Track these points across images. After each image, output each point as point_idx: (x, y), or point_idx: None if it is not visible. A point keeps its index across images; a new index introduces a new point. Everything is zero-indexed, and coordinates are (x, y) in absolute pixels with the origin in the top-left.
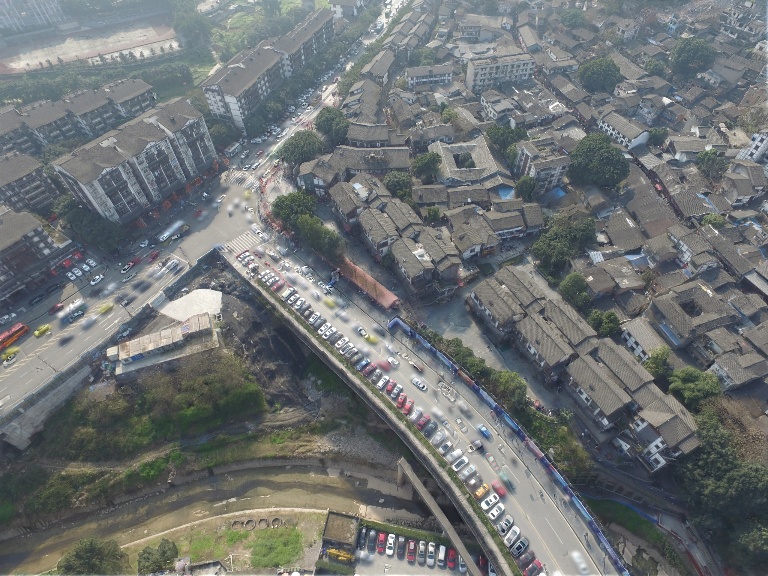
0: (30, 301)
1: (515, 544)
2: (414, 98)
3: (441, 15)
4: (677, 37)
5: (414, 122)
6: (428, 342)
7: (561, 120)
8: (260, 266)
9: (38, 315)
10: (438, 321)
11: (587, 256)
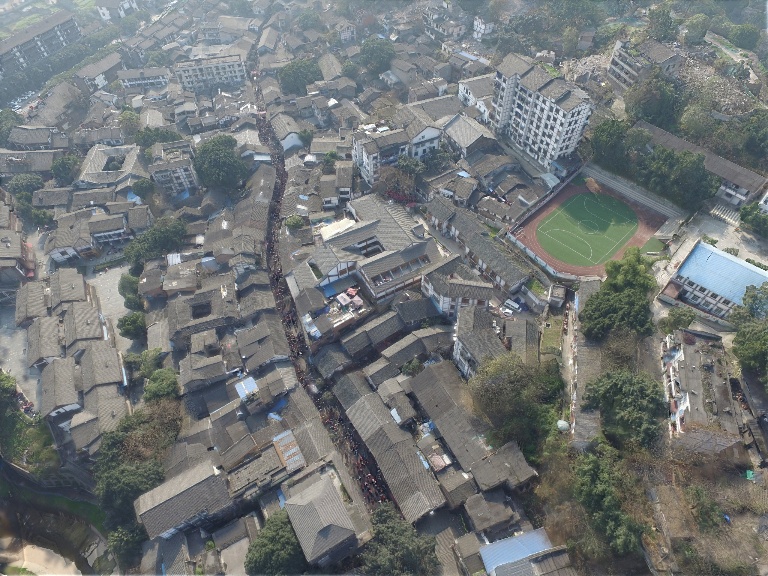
0: None
1: None
2: (113, 100)
3: (194, 17)
4: (389, 38)
5: (101, 125)
6: None
7: (239, 122)
8: None
9: None
10: None
11: (163, 258)
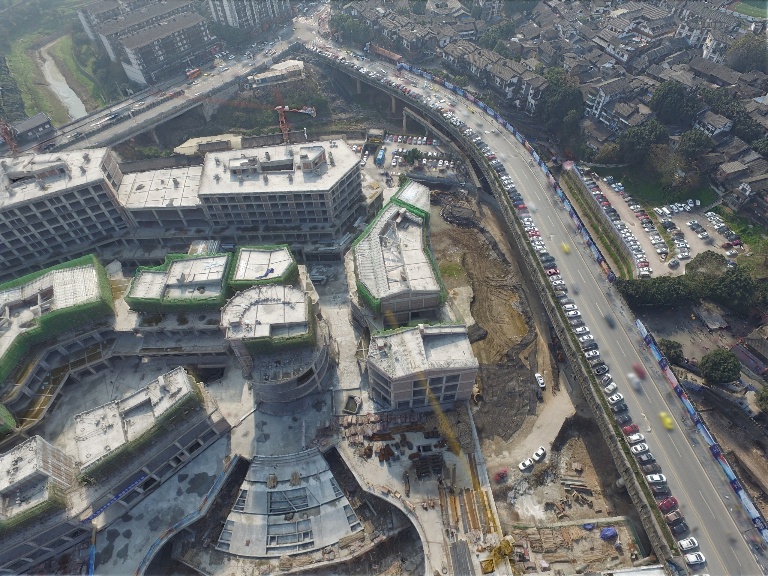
0: (198, 64)
1: None
2: None
3: None
4: None
5: None
6: (419, 69)
7: None
8: (323, 52)
9: (204, 69)
10: None
11: (509, 40)
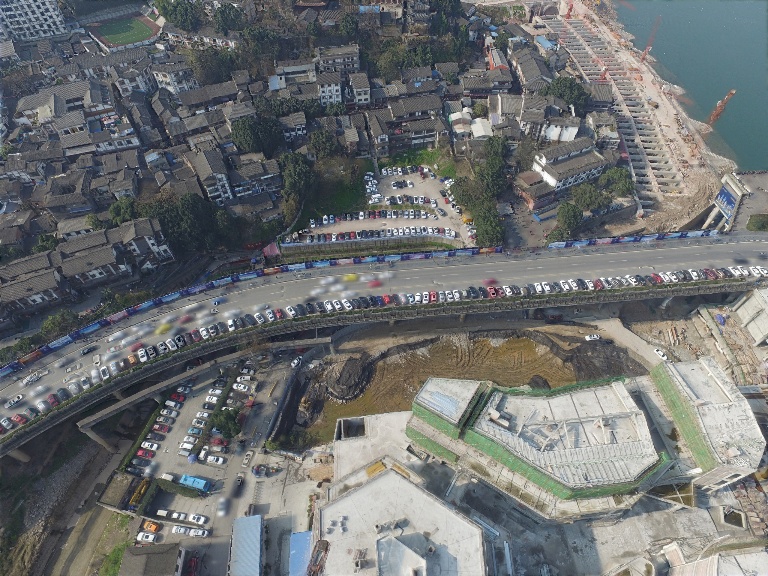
0: None
1: (176, 343)
2: None
3: None
4: None
5: None
6: None
7: None
8: None
9: None
10: None
11: None
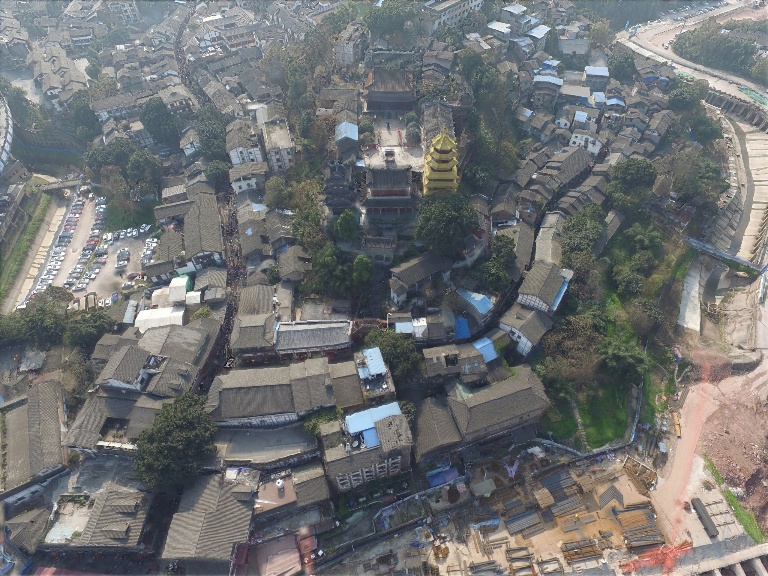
0: None
1: None
2: None
3: None
4: None
5: None
6: None
7: None
8: None
9: None
10: (11, 77)
11: (114, 46)
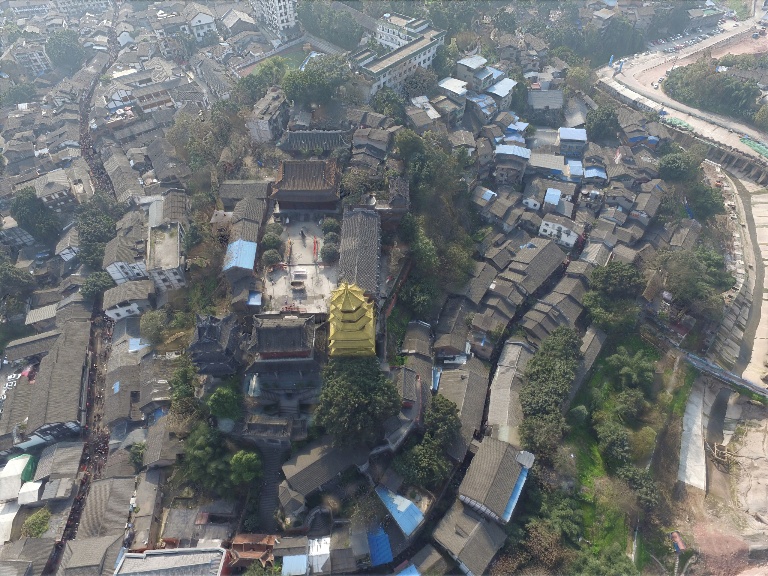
0: None
1: None
2: (3, 21)
3: None
4: None
5: None
6: None
7: None
8: None
9: None
10: None
11: (15, 106)
